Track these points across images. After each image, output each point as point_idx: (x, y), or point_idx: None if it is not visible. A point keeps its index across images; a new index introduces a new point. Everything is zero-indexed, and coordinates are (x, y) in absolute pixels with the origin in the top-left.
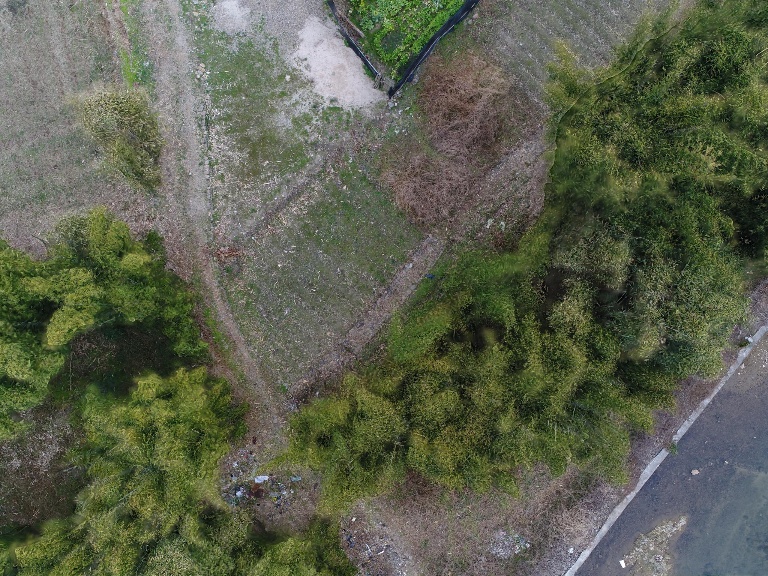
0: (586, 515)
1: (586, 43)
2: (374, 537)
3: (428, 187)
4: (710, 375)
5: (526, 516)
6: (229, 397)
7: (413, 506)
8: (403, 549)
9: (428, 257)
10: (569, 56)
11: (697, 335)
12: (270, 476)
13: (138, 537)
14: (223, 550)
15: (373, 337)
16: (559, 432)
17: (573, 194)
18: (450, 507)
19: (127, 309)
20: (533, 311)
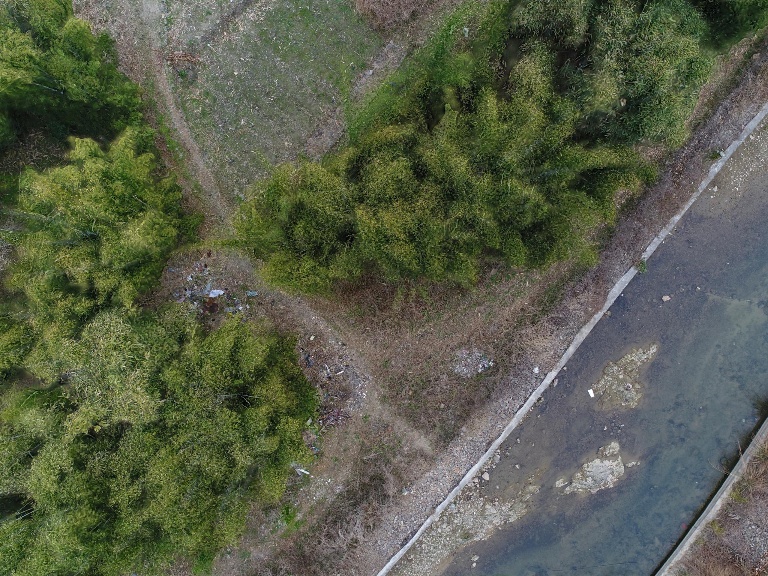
0: (551, 331)
1: None
2: (333, 357)
3: None
4: (673, 142)
5: (490, 334)
6: (180, 194)
7: (373, 323)
8: (363, 369)
9: (389, 64)
10: None
11: (656, 83)
12: (225, 290)
13: (76, 304)
14: (168, 335)
15: (332, 147)
16: (513, 187)
17: None
18: (411, 324)
19: (70, 83)
20: (490, 84)
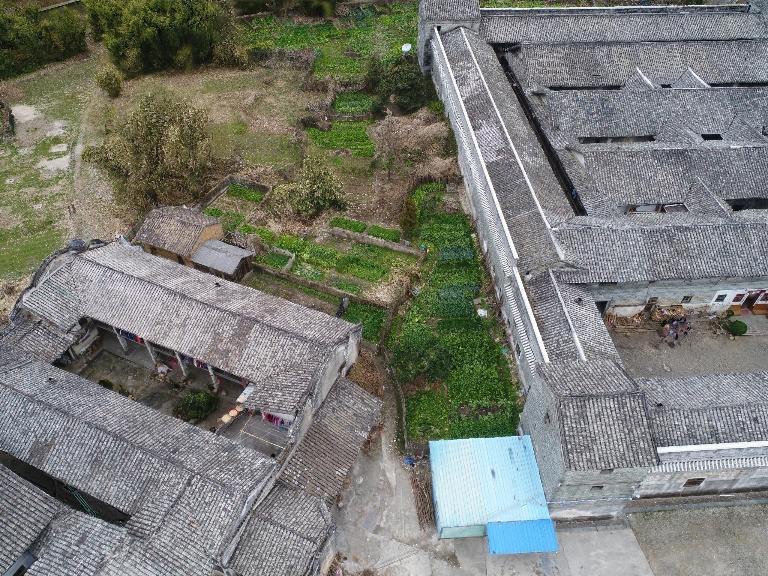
0: None
1: None
2: None
3: (7, 92)
4: None
5: None
6: None
7: None
8: None
9: None
10: None
11: None
12: None
13: None
14: None
15: None
16: None
17: None
18: None
19: None
20: None
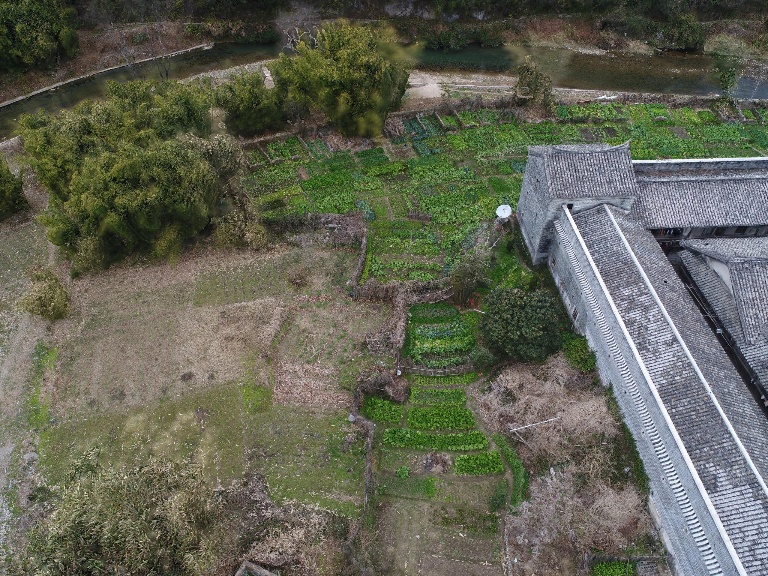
0: None
1: None
2: (24, 181)
3: None
4: None
5: None
6: None
7: None
8: None
9: None
10: None
11: None
12: None
13: (85, 137)
14: None
15: None
16: None
17: None
18: None
19: None
20: None
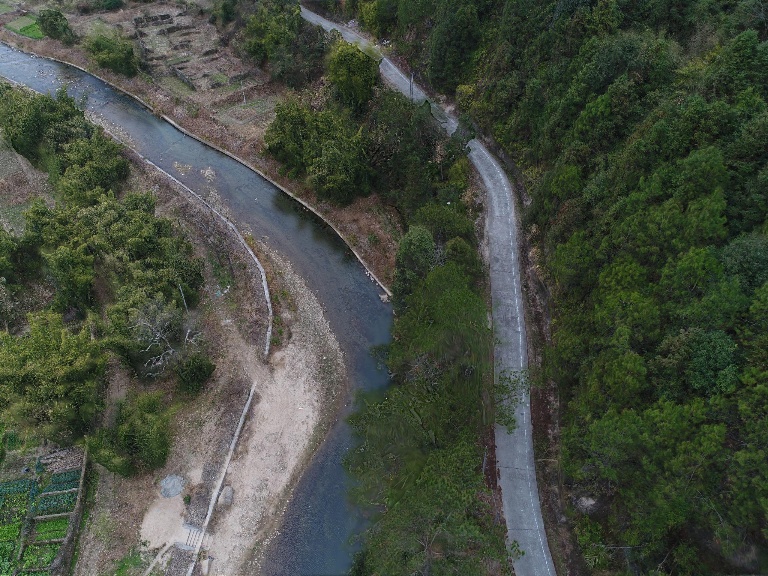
0: None
1: (5, 164)
2: None
3: None
4: None
5: None
6: None
7: None
8: None
9: None
10: (6, 167)
11: None
12: None
13: (70, 221)
14: None
15: None
16: None
17: (39, 149)
18: None
19: None
20: None
